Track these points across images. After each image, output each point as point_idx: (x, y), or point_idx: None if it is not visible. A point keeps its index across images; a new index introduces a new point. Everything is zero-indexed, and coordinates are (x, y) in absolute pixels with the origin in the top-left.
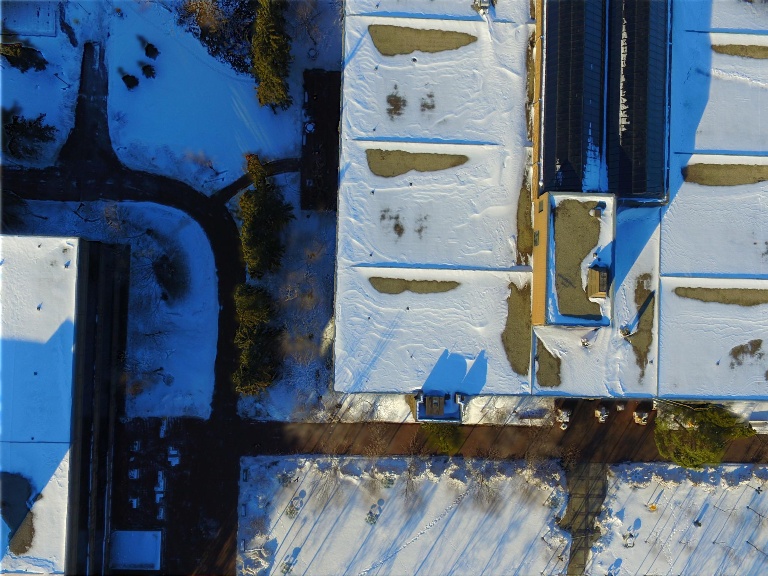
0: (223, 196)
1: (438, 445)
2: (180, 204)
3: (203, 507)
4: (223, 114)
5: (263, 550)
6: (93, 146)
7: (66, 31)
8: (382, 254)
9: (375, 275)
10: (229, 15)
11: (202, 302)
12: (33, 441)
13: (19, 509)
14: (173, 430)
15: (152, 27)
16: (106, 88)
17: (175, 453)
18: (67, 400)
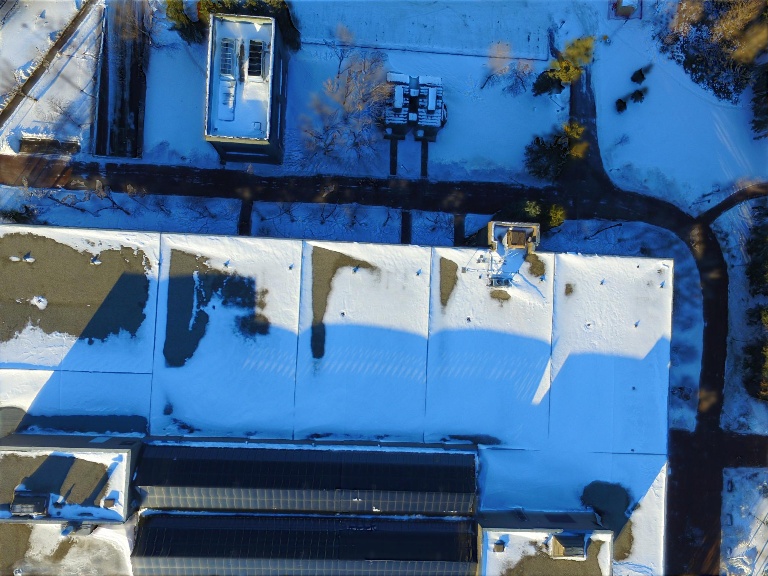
0: (708, 217)
1: None
2: (669, 224)
3: (689, 516)
4: (707, 139)
5: (746, 558)
6: (586, 167)
7: (555, 55)
8: None
9: None
10: (712, 44)
11: (690, 319)
12: (633, 452)
13: (618, 517)
14: None
15: (636, 53)
16: (594, 111)
17: (668, 464)
18: (664, 414)
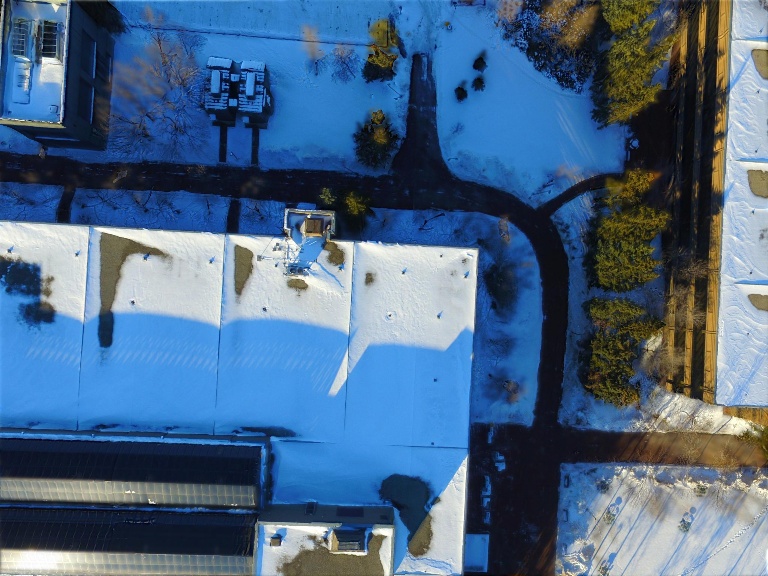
0: (548, 208)
1: (748, 456)
2: (508, 215)
3: (525, 512)
4: (549, 128)
5: (582, 555)
6: (424, 156)
7: (396, 42)
8: (762, 272)
9: (755, 292)
10: (556, 31)
11: (528, 311)
12: (433, 446)
13: (417, 512)
14: (498, 436)
15: (479, 40)
16: (434, 99)
17: (502, 458)
18: (466, 407)
